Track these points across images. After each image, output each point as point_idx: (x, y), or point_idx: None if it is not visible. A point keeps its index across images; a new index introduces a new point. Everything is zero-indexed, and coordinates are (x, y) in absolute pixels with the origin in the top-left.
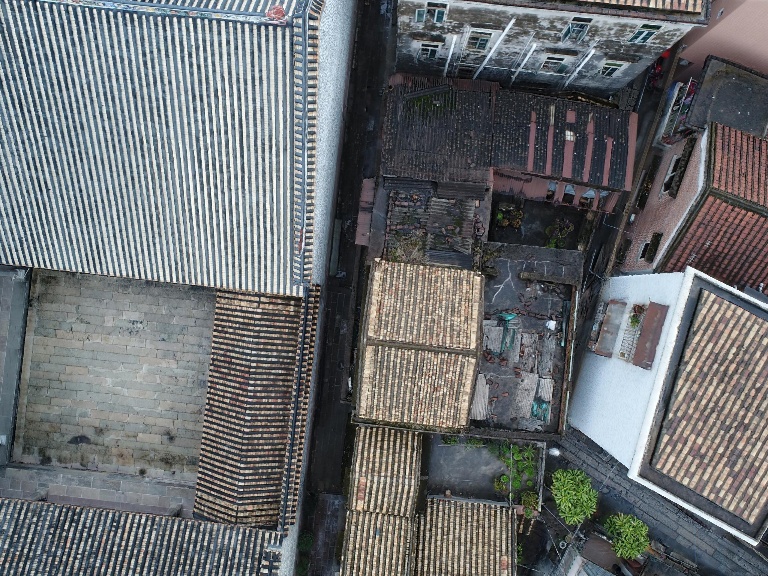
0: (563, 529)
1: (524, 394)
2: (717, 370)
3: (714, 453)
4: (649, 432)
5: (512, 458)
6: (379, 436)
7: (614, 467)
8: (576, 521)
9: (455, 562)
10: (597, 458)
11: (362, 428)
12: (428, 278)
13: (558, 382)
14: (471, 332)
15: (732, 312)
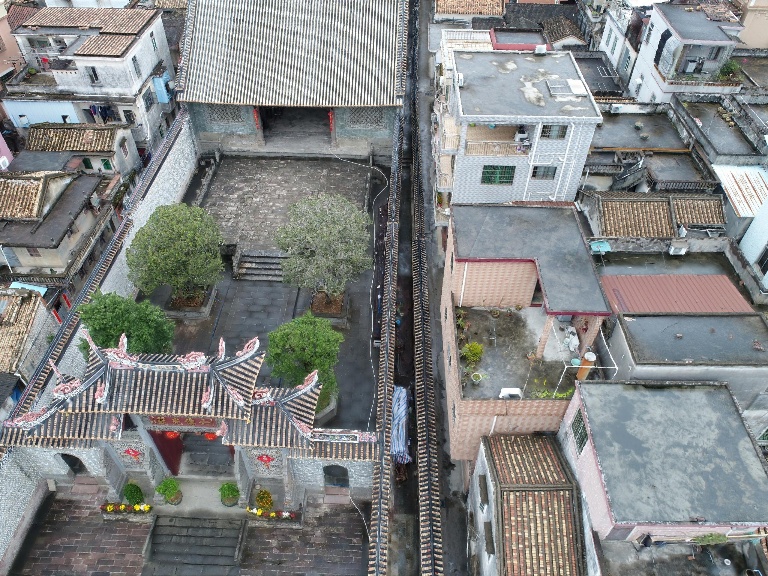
0: None
1: None
2: None
3: None
4: None
5: None
6: None
7: None
8: None
9: None
10: None
11: None
12: (175, 4)
13: None
14: None
15: None
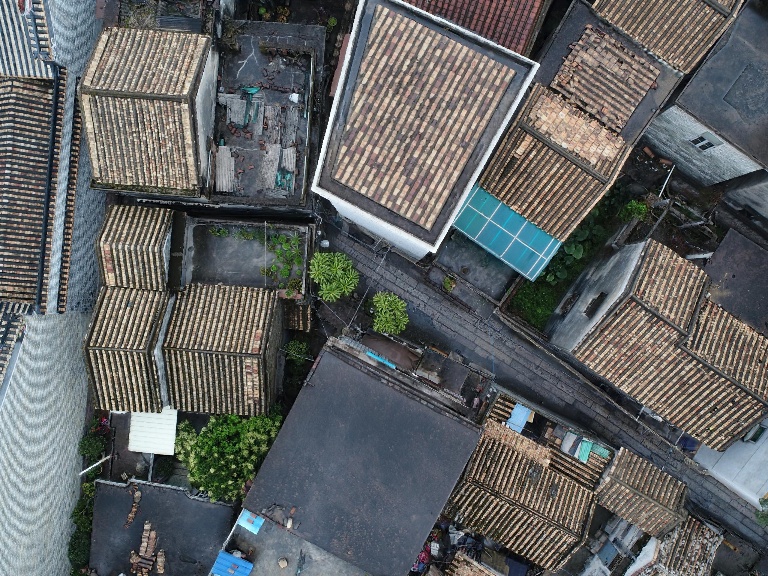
0: (341, 323)
1: (269, 165)
2: (392, 82)
3: (391, 162)
4: (327, 143)
5: (281, 248)
6: (131, 213)
7: (384, 257)
8: (332, 297)
9: (211, 336)
10: (395, 273)
11: (115, 206)
12: (156, 41)
13: (303, 154)
14: (187, 81)
15: (405, 25)
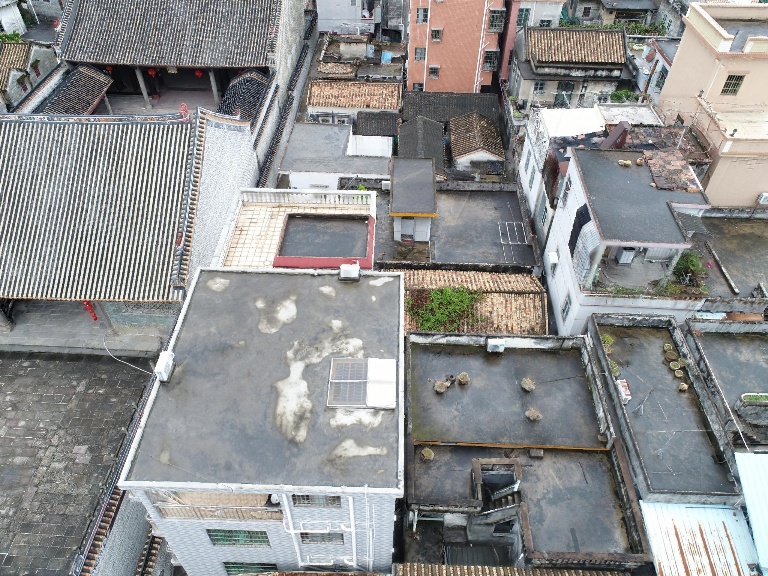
0: None
1: None
2: None
3: None
4: None
5: None
6: None
7: None
8: None
9: None
10: None
11: (3, 89)
12: None
13: None
14: None
15: None
